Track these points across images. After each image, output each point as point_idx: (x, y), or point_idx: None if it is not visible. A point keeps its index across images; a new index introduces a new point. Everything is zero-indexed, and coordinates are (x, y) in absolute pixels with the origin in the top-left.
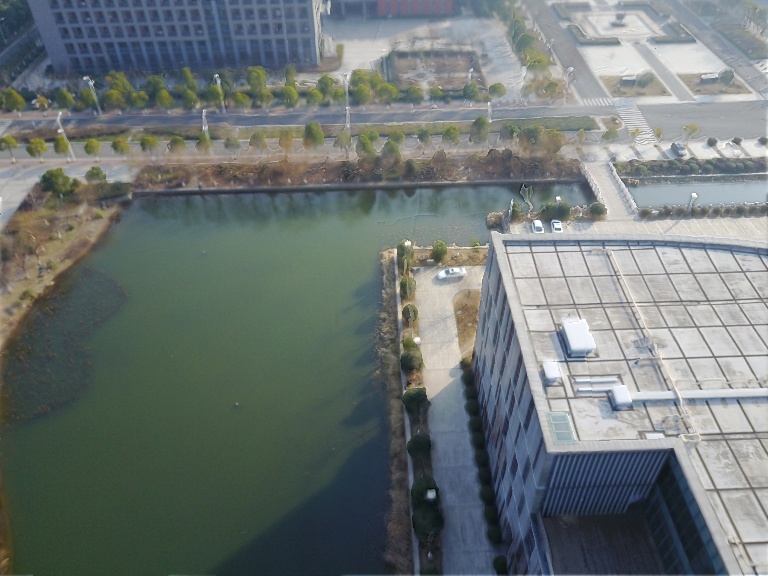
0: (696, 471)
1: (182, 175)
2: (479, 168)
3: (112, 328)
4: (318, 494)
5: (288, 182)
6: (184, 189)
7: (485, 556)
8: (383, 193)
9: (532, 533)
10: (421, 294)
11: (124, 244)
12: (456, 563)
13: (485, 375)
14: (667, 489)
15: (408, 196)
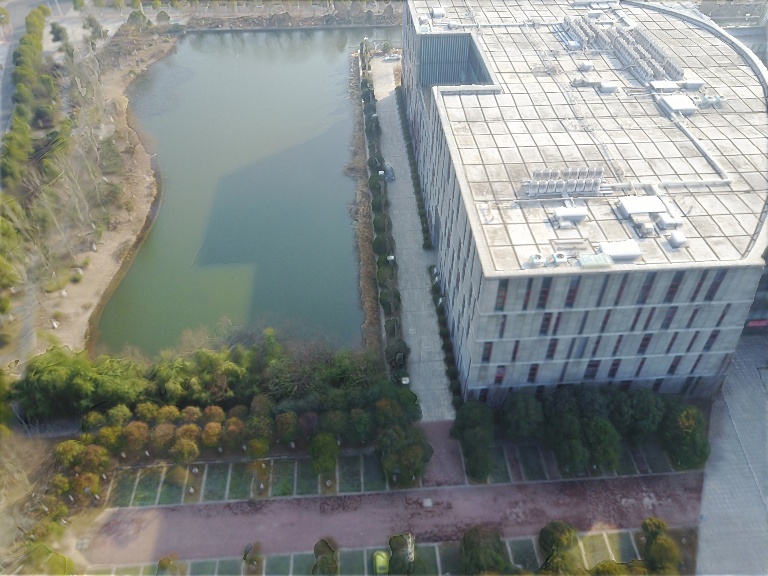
0: (479, 40)
1: (218, 21)
2: None
3: (188, 85)
4: (316, 136)
5: (289, 25)
6: (220, 29)
7: (402, 145)
8: (352, 36)
9: None
10: (374, 67)
11: (182, 62)
12: (387, 148)
13: None
14: (471, 58)
15: (369, 37)
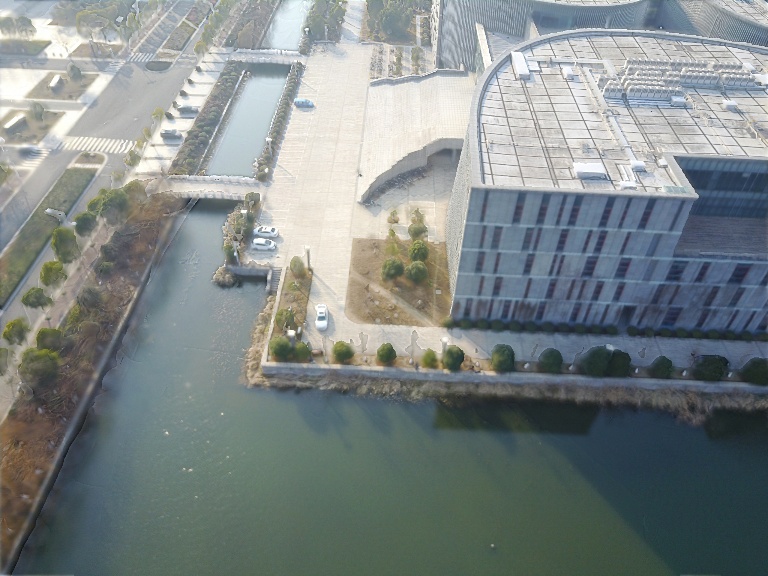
0: None
1: None
2: (122, 270)
3: None
4: (590, 458)
5: (27, 499)
6: None
7: (627, 340)
8: None
9: (675, 266)
10: None
11: None
12: (636, 358)
13: (507, 288)
14: None
15: None
